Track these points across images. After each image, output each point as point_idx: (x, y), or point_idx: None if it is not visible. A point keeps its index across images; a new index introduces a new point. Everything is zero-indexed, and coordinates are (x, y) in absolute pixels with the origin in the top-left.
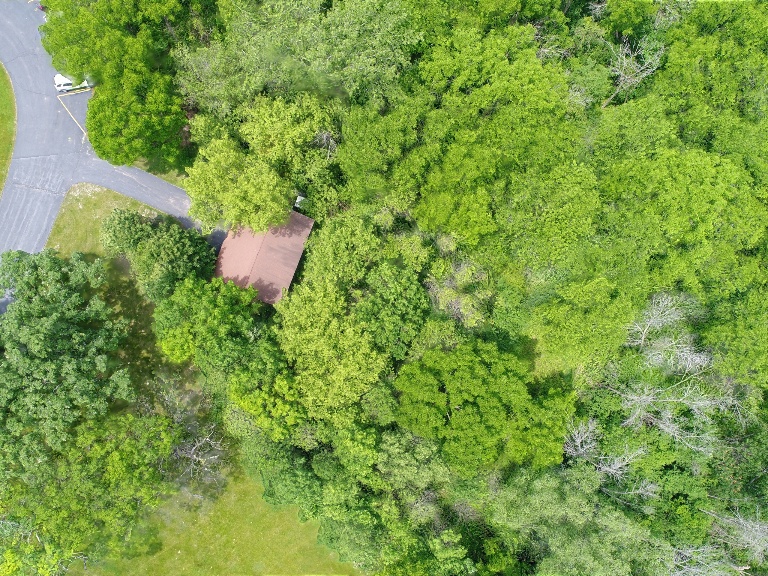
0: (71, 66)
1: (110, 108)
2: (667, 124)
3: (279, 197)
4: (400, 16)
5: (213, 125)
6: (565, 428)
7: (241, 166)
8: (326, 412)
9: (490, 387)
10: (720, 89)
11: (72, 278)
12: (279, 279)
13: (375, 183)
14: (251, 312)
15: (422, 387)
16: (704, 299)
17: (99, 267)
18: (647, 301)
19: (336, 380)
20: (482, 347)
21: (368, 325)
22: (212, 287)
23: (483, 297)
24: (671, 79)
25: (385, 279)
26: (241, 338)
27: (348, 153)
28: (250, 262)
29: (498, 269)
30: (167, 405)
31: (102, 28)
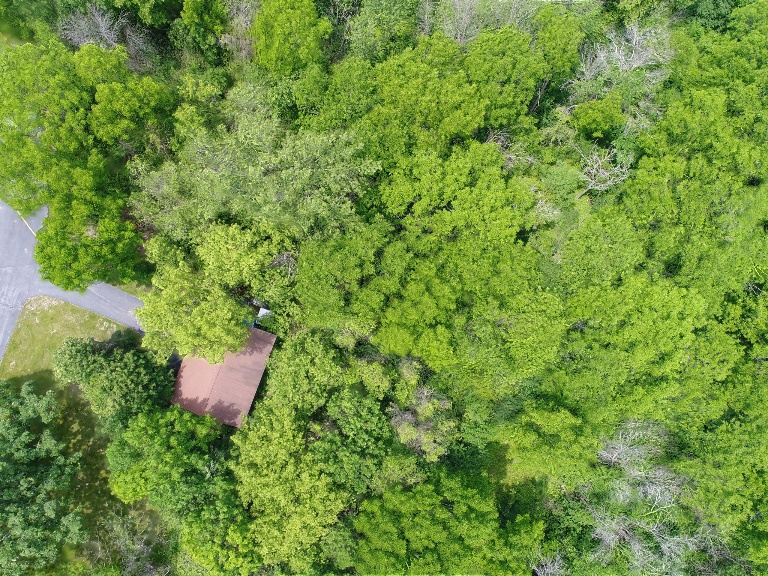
0: (17, 202)
1: (59, 242)
2: (633, 252)
3: (235, 329)
4: (357, 147)
5: (168, 249)
6: (529, 573)
7: (197, 293)
8: (283, 556)
9: (451, 532)
10: (688, 213)
11: (22, 413)
12: (240, 399)
13: (333, 317)
14: (209, 440)
15: (380, 535)
16: (672, 434)
17: (50, 401)
18: (613, 437)
19: (291, 529)
20: (445, 483)
21: (326, 466)
22: (167, 422)
23: (446, 429)
24: (639, 197)
25: (345, 411)
26: (197, 475)
27: (304, 288)
28: (210, 383)
29: (464, 391)
30: (127, 527)
31: (49, 161)
